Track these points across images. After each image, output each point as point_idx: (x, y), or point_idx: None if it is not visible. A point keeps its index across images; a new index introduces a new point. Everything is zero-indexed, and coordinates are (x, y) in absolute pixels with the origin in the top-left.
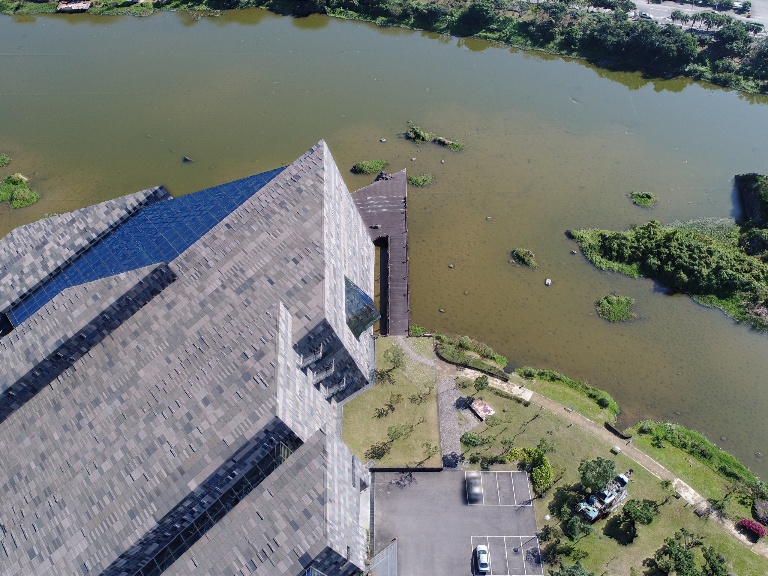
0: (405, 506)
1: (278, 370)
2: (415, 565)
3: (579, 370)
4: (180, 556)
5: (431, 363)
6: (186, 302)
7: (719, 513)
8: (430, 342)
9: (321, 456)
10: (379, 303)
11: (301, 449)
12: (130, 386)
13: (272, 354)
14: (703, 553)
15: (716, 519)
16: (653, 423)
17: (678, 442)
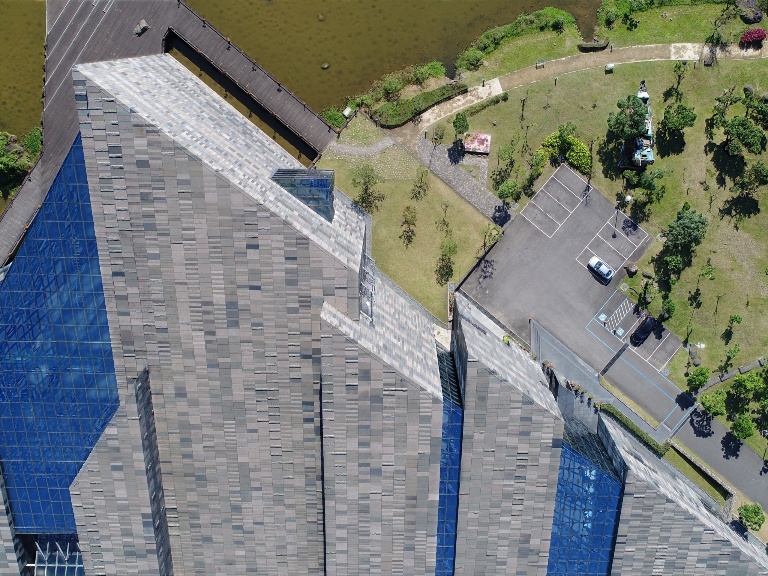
0: (510, 289)
1: (398, 371)
2: (562, 322)
3: (505, 5)
4: (458, 519)
5: (389, 142)
6: (193, 378)
7: (721, 47)
8: (363, 120)
9: (493, 378)
10: (263, 122)
11: (469, 388)
12: (248, 476)
13: (376, 365)
14: (746, 106)
15: (723, 55)
16: (609, 2)
17: (645, 4)
